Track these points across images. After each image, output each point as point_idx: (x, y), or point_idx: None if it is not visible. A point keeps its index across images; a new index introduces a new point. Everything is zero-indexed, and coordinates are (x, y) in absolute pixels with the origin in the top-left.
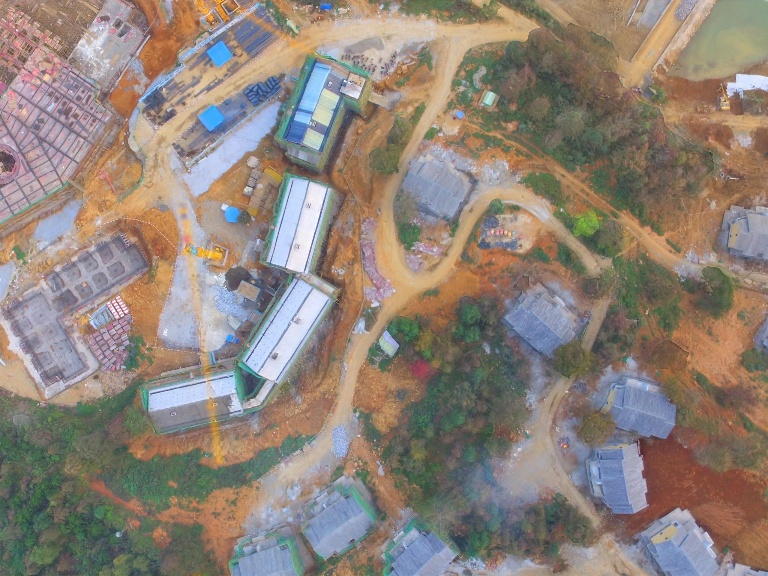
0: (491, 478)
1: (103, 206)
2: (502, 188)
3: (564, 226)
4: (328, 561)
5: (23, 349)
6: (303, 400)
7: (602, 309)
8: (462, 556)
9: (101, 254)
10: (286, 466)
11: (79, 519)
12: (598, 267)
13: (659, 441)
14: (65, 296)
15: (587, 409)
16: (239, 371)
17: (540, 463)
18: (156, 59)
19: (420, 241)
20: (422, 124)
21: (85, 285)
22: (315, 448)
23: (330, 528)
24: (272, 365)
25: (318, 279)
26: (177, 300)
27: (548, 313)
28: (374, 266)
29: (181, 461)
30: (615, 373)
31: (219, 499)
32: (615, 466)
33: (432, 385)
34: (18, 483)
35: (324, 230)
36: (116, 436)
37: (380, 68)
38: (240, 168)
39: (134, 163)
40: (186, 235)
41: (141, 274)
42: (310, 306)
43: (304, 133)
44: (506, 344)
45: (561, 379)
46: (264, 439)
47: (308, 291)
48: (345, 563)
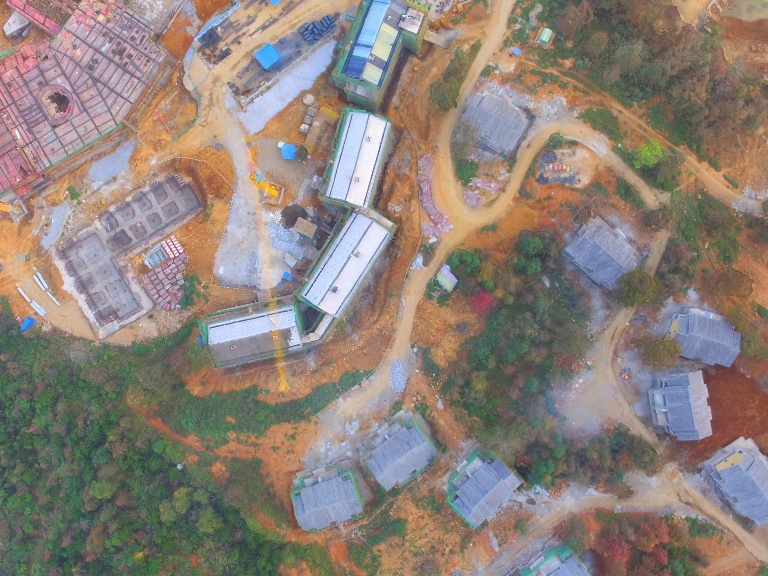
0: (553, 409)
1: (158, 145)
2: (560, 123)
3: (622, 161)
4: (388, 494)
5: (77, 289)
6: (359, 337)
7: (661, 243)
8: (525, 485)
9: (155, 194)
10: (344, 401)
11: (137, 454)
12: (657, 201)
13: (722, 371)
14: (119, 236)
15: (648, 340)
16: (297, 306)
17: (602, 394)
18: (209, 0)
19: (477, 177)
20: (478, 61)
21: (139, 225)
22: (373, 383)
23: (393, 458)
24: (332, 298)
25: (377, 213)
26: (233, 238)
27: (610, 243)
28: (431, 202)
29: (238, 397)
30: (676, 305)
31: (278, 434)
32: (681, 392)
33: (491, 319)
34: (74, 421)
35: (381, 167)
36: (177, 368)
37: (435, 7)
38: (296, 106)
39: (188, 103)
40: (242, 173)
41: (195, 214)
42: (370, 240)
43: (363, 67)
44: (566, 277)
45: (621, 311)
46: (321, 375)
47: (368, 224)
48: (406, 495)
